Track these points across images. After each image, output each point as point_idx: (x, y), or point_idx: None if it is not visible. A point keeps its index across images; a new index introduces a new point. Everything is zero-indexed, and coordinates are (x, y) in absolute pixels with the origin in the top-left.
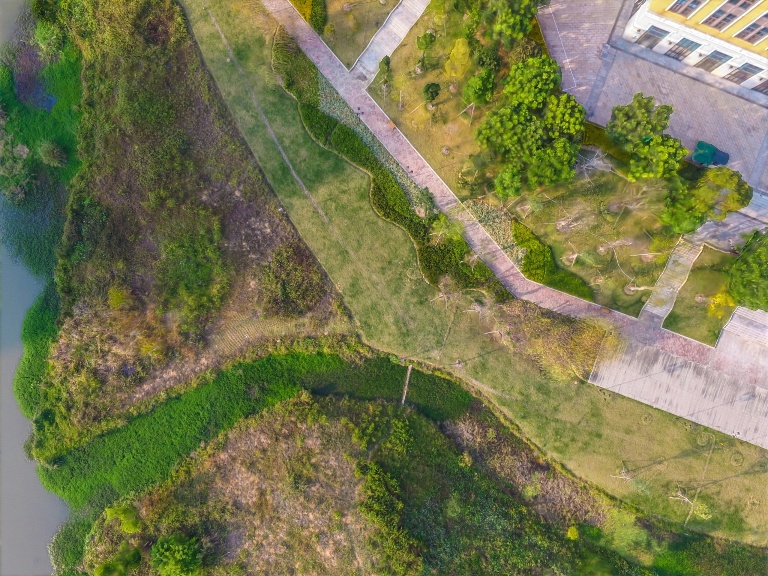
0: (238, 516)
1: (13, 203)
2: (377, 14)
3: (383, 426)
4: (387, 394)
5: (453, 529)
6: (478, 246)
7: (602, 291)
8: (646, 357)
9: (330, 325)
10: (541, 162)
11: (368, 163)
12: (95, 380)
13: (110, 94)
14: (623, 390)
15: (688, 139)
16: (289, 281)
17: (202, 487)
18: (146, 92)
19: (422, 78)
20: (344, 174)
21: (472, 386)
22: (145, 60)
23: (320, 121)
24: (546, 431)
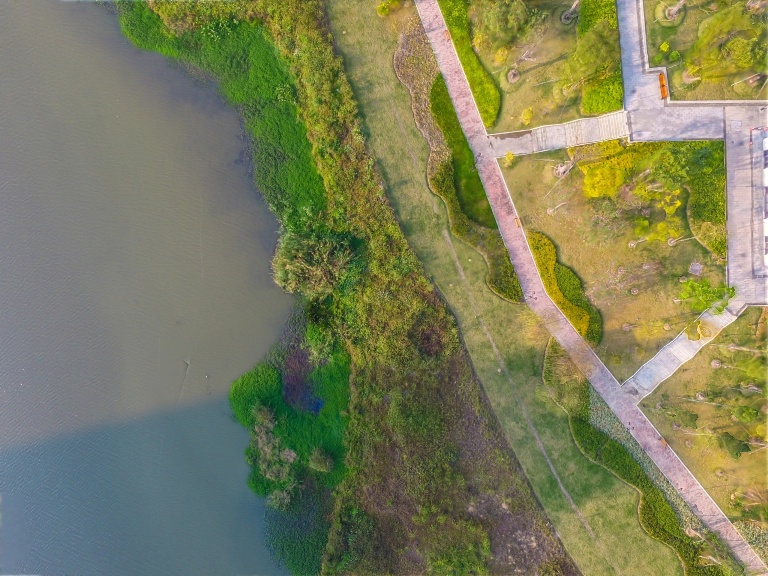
0: None
1: (278, 508)
2: (659, 338)
3: None
4: None
5: None
6: (746, 567)
7: None
8: None
9: None
10: None
11: (639, 481)
12: None
13: (380, 402)
14: None
15: None
16: None
17: None
18: (419, 405)
19: (702, 403)
20: (612, 489)
21: None
22: (419, 372)
23: (591, 436)
24: None
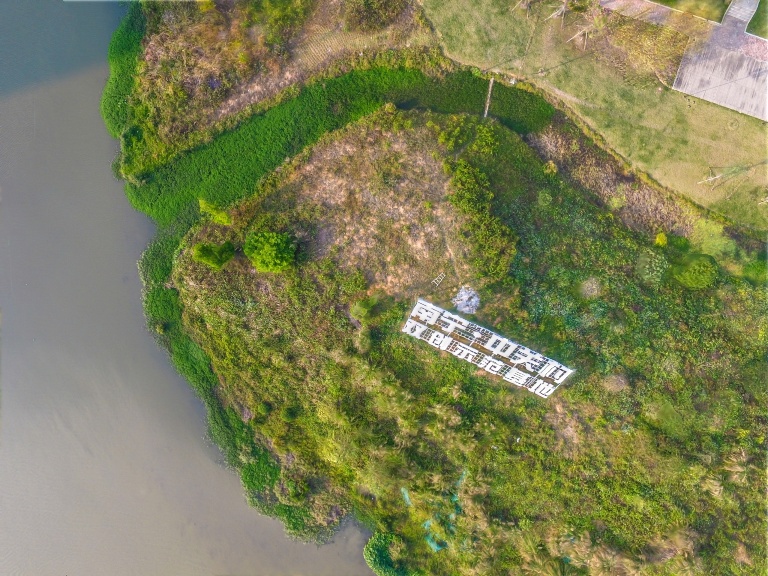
0: (328, 214)
1: None
2: None
3: (468, 131)
4: (469, 108)
5: (542, 227)
6: None
7: None
8: (730, 62)
9: (412, 37)
10: None
11: None
12: (183, 90)
13: None
14: (708, 96)
15: None
16: None
17: (289, 196)
18: None
19: None
20: None
21: (555, 97)
22: None
23: None
24: (631, 139)
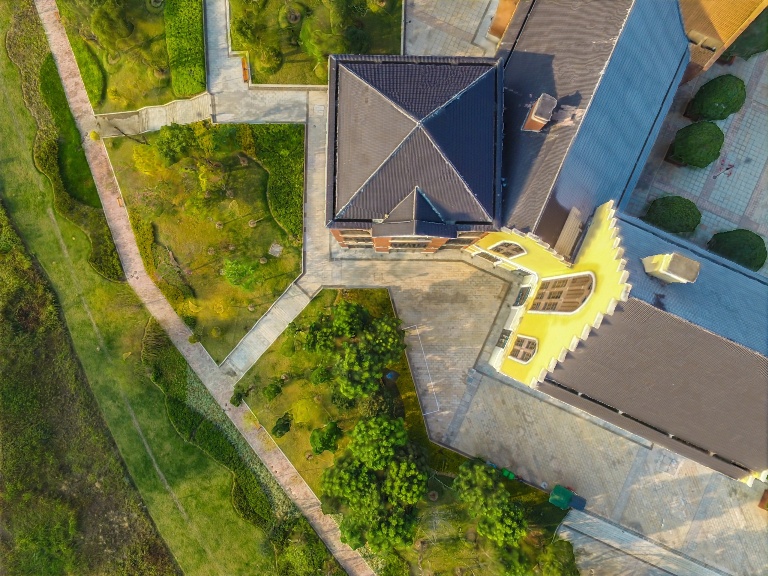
0: None
1: None
2: (246, 319)
3: None
4: None
5: None
6: (339, 551)
7: None
8: None
9: None
10: None
11: (231, 462)
12: None
13: None
14: None
15: (551, 470)
16: None
17: None
18: (11, 381)
19: (288, 385)
20: (207, 470)
21: None
22: (12, 348)
23: (185, 417)
24: None
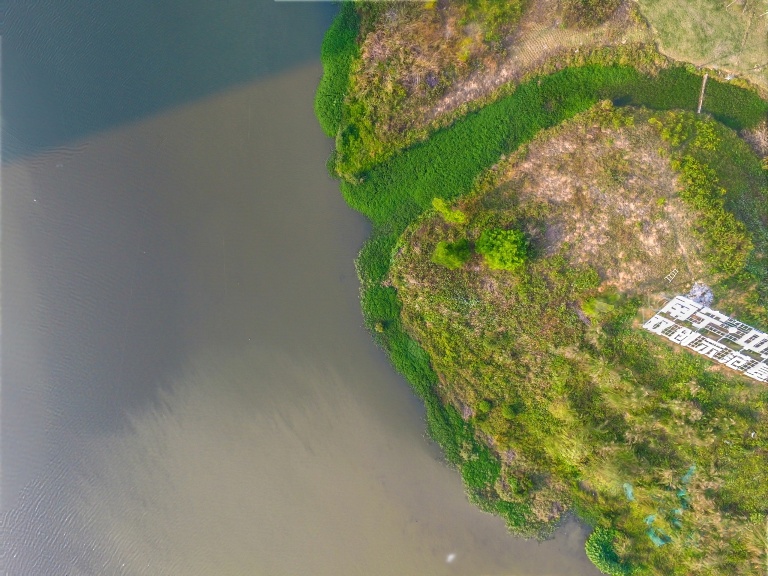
0: (557, 211)
1: None
2: None
3: (689, 127)
4: (683, 104)
5: None
6: None
7: None
8: None
9: (627, 34)
10: None
11: None
12: (403, 89)
13: None
14: None
15: None
16: None
17: (510, 193)
18: None
19: None
20: None
21: None
22: None
23: None
24: None
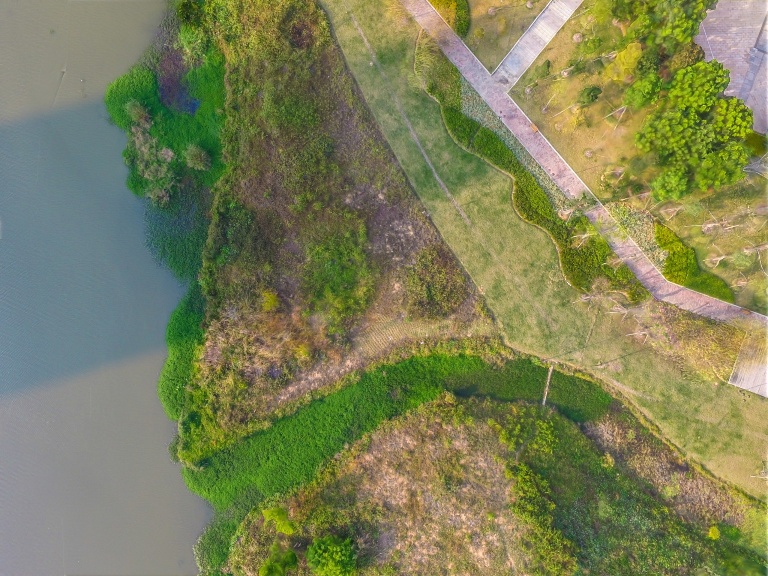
0: (390, 517)
1: (158, 206)
2: (523, 18)
3: (528, 427)
4: (528, 395)
5: (601, 529)
6: (619, 248)
7: (743, 293)
8: None
9: (473, 327)
10: (712, 165)
11: (511, 166)
12: (243, 382)
13: (254, 98)
14: (763, 391)
15: None
16: (434, 283)
17: (349, 488)
18: (292, 96)
19: (567, 81)
20: (486, 177)
21: (613, 387)
22: (290, 64)
23: (463, 124)
24: (686, 432)
